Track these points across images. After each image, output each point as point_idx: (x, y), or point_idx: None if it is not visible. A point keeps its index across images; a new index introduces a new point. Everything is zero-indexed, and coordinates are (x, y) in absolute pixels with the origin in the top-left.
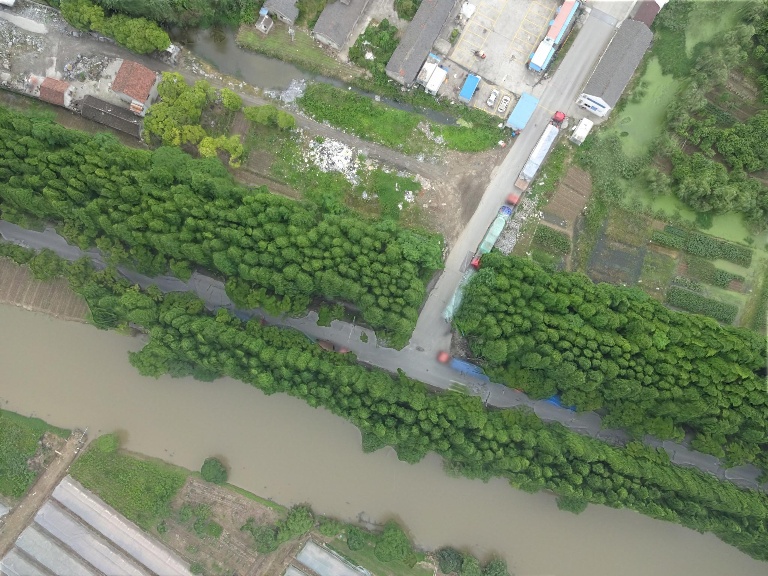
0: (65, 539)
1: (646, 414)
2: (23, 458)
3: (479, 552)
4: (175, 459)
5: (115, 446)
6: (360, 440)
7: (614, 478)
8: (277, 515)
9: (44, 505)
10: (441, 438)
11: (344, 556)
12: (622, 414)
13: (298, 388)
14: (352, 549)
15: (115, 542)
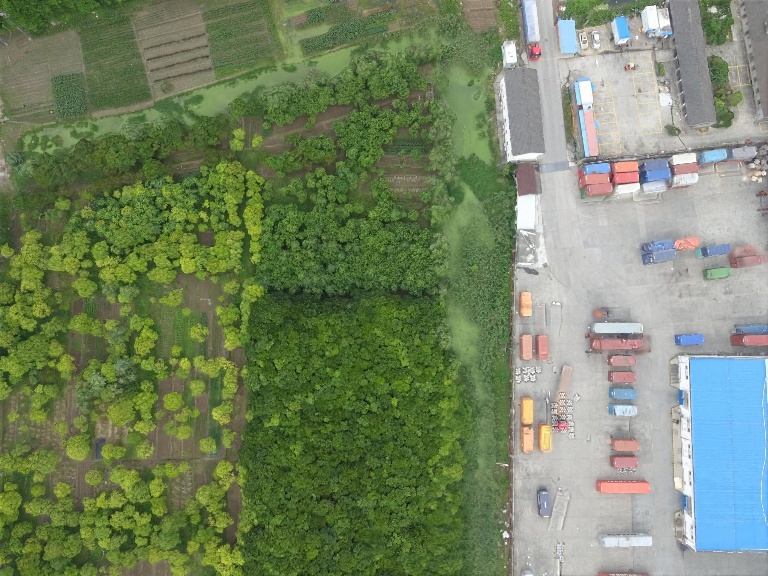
0: None
1: None
2: None
3: None
4: None
5: None
6: None
7: None
8: None
9: None
10: None
11: None
12: None
13: None
14: None
15: None
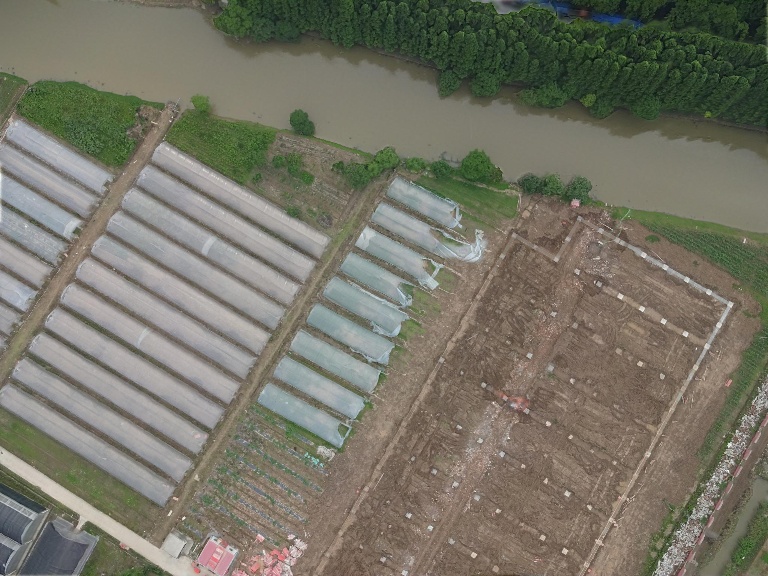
0: (167, 198)
1: (710, 2)
2: (123, 127)
3: (560, 176)
4: (263, 120)
5: (208, 106)
6: (435, 90)
7: (687, 48)
8: (364, 160)
9: (146, 167)
10: (517, 41)
11: (431, 190)
12: (687, 2)
13: (378, 8)
14: (439, 175)
15: (214, 195)
